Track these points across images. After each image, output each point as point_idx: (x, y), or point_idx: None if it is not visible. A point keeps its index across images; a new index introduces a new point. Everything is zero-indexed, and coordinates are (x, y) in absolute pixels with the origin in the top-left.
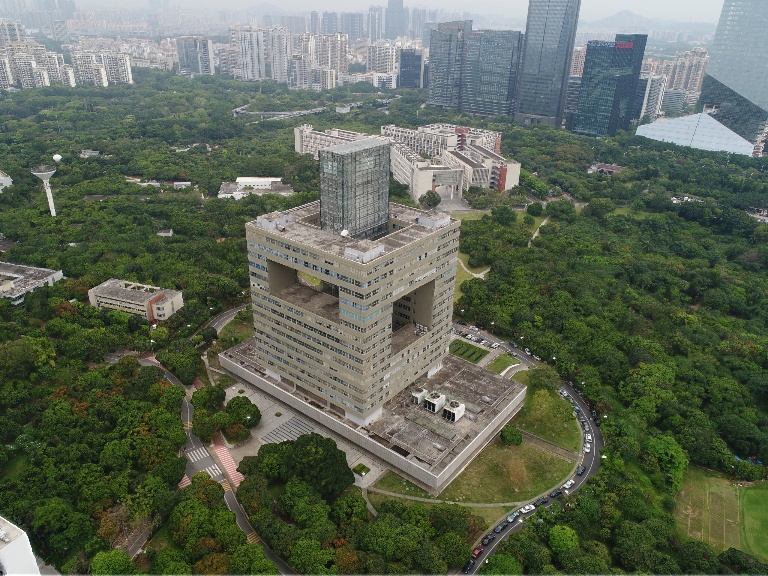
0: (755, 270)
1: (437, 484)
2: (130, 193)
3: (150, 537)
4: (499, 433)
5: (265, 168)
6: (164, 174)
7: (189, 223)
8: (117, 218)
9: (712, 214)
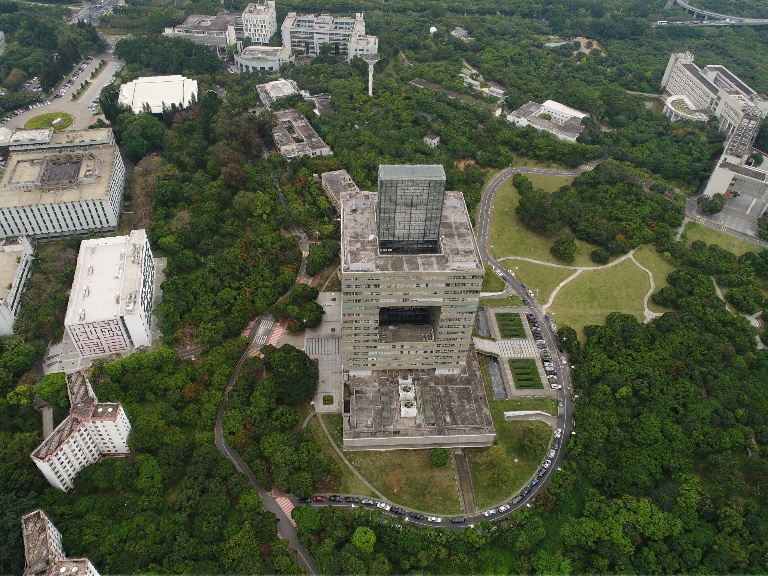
0: None
1: (344, 443)
2: (447, 87)
3: (201, 353)
4: (446, 449)
5: (576, 100)
6: (493, 74)
7: (454, 137)
8: (403, 113)
9: None
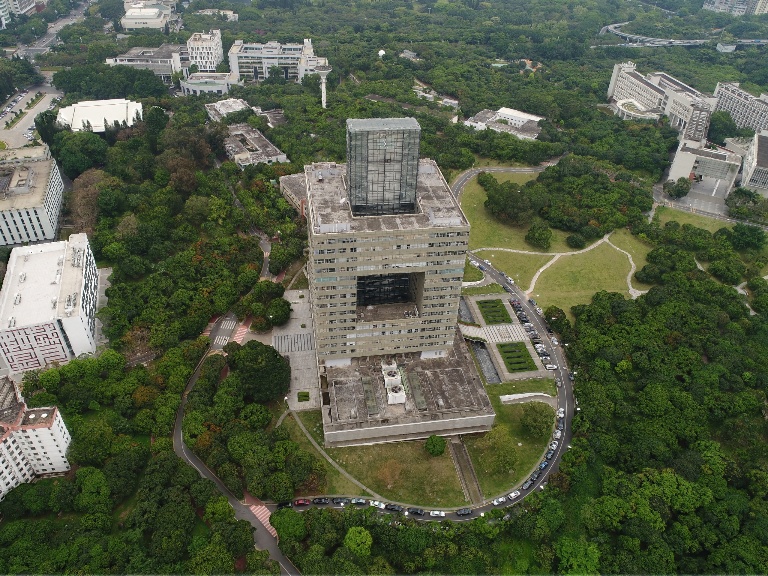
0: None
1: (326, 439)
2: (401, 100)
3: (154, 358)
4: None
5: (531, 104)
6: (445, 88)
7: None
8: None
9: None
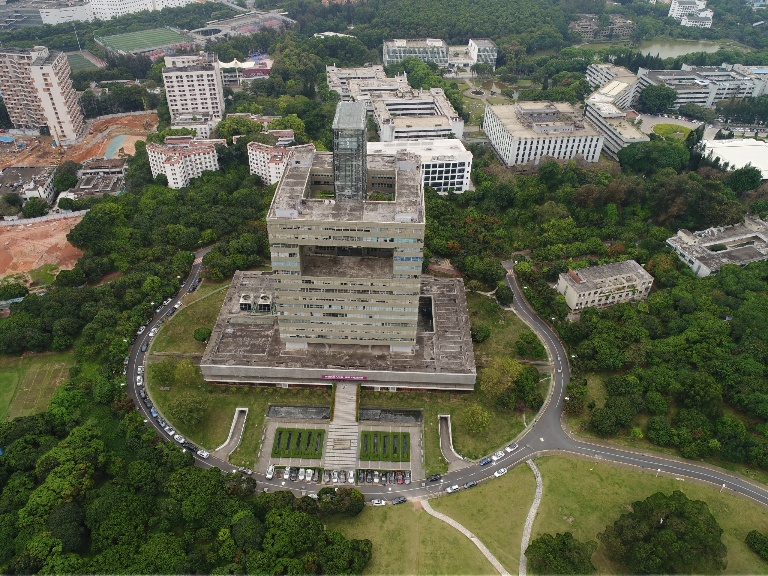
0: None
1: None
2: None
3: None
4: None
5: None
6: None
7: None
8: None
9: None
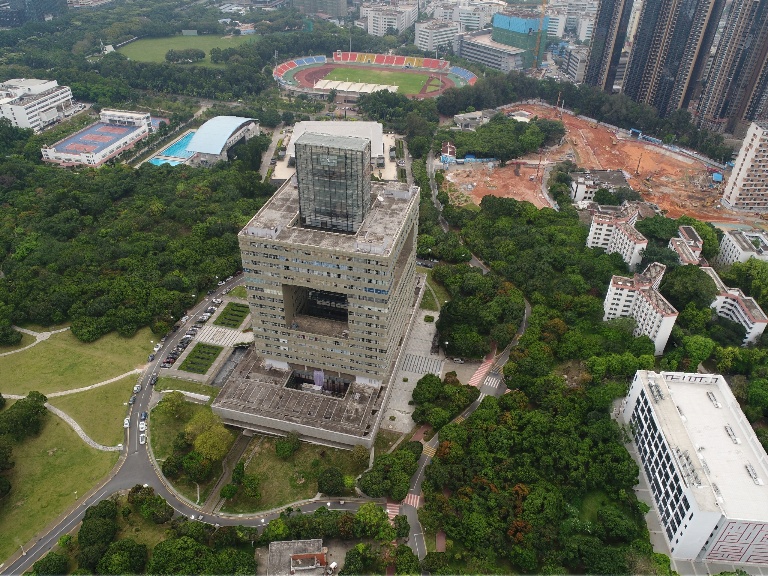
0: (23, 186)
1: None
2: None
3: None
4: None
5: None
6: None
7: None
8: None
9: None
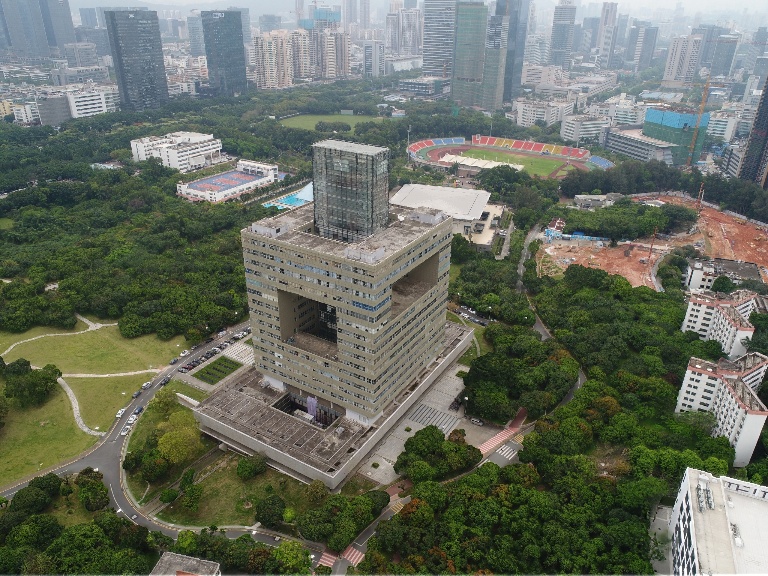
0: (149, 210)
1: None
2: None
3: None
4: None
5: None
6: None
7: None
8: None
9: (44, 195)
